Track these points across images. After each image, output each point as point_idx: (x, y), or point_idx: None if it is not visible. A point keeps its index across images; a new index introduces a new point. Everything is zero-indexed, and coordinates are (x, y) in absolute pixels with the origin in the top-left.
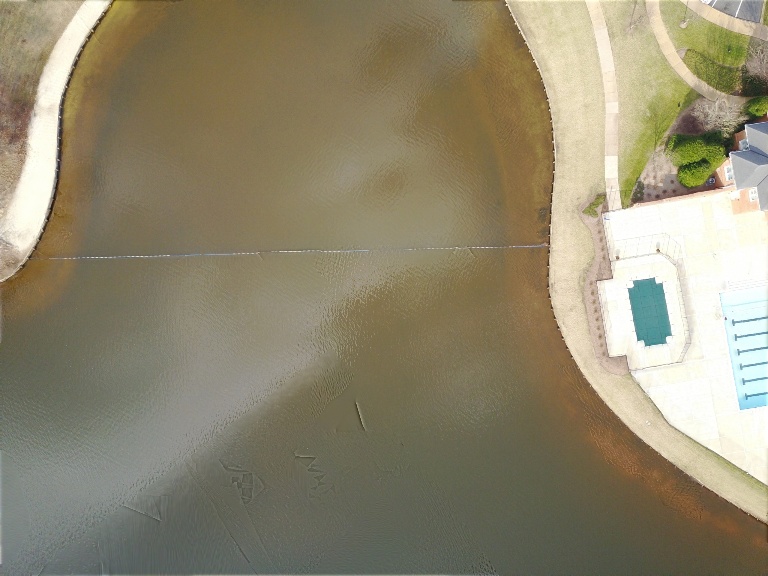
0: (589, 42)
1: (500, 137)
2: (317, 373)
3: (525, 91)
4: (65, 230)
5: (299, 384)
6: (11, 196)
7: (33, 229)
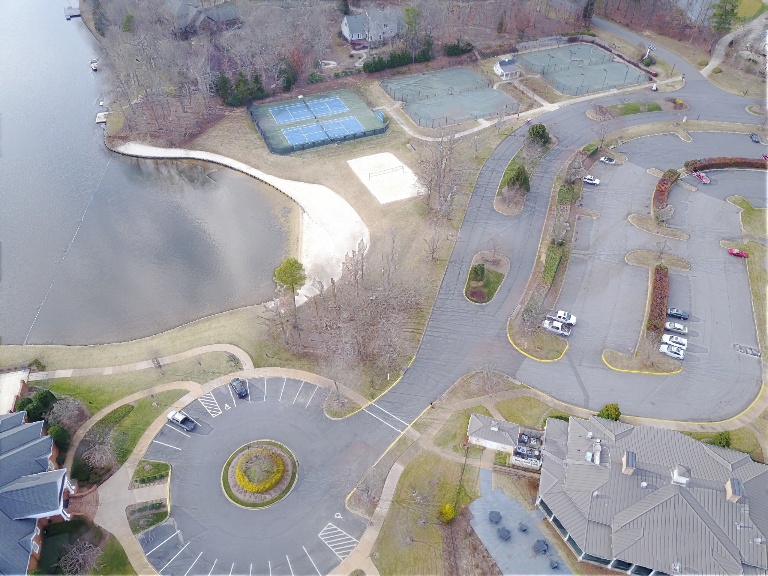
0: (162, 354)
1: (115, 320)
2: (6, 262)
3: (143, 332)
4: (145, 183)
5: (3, 255)
6: (147, 145)
7: (128, 151)
